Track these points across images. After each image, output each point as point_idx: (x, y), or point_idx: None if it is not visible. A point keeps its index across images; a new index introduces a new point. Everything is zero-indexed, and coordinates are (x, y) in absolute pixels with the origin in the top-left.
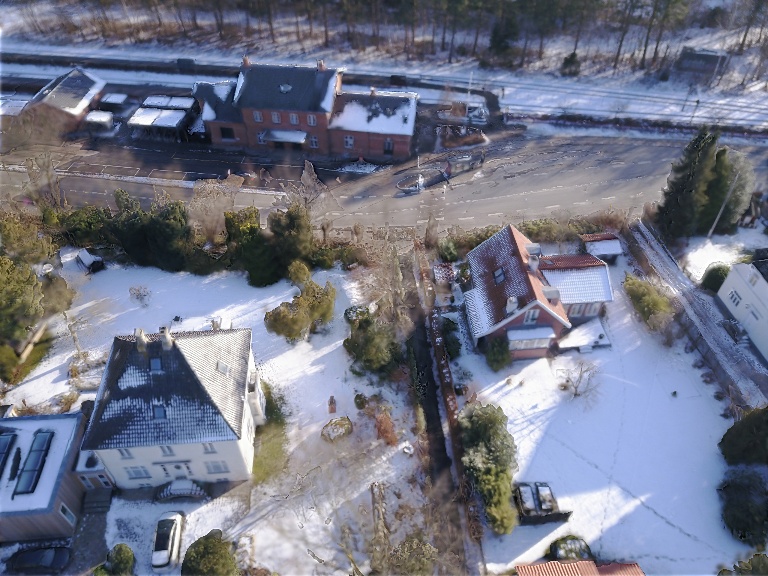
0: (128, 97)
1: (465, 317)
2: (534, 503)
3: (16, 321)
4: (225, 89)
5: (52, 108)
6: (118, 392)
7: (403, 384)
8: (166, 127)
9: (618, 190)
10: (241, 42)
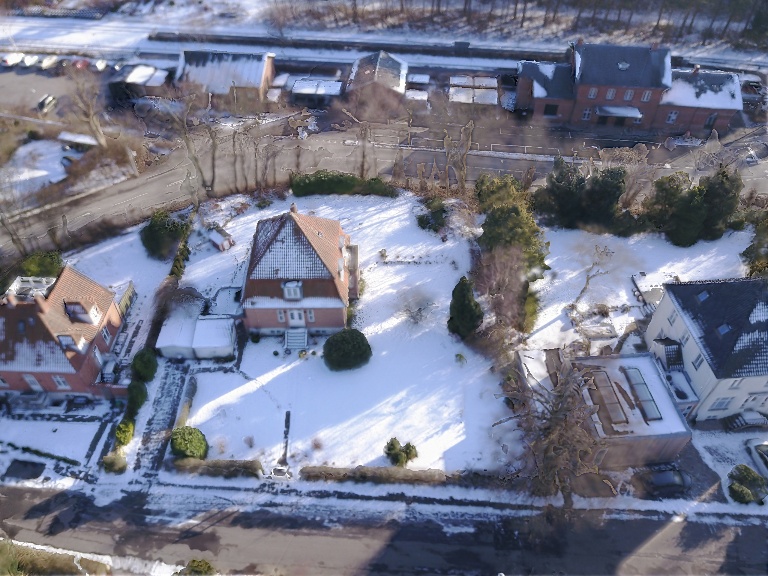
0: (429, 78)
1: None
2: None
3: (535, 273)
4: (549, 68)
5: (381, 87)
6: (748, 326)
7: None
8: (485, 105)
9: None
10: (491, 27)
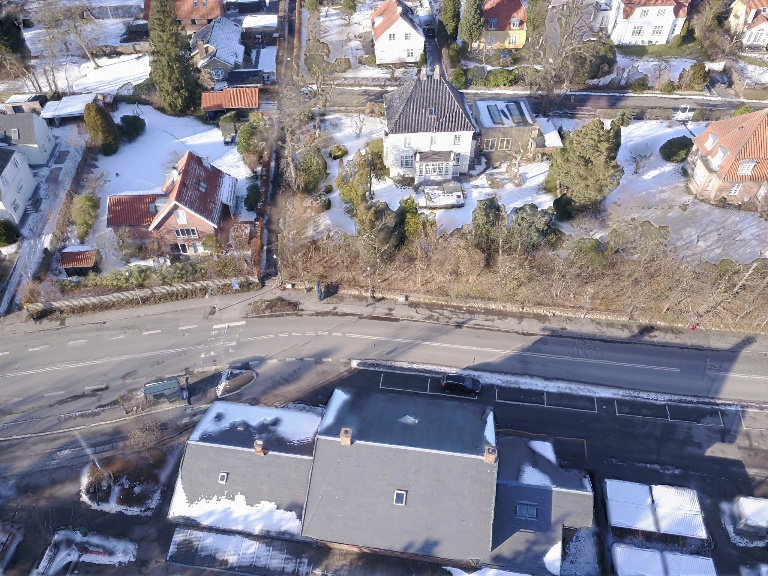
0: None
1: (235, 216)
2: (236, 136)
3: None
4: (530, 481)
5: None
6: None
7: None
8: None
9: None
10: None
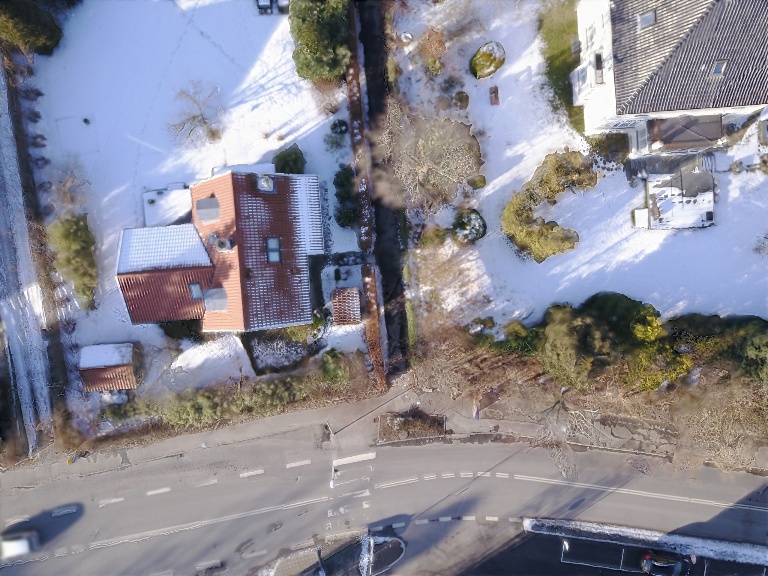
0: None
1: None
2: None
3: None
4: None
5: None
6: None
7: (409, 135)
8: None
9: (43, 535)
10: None
